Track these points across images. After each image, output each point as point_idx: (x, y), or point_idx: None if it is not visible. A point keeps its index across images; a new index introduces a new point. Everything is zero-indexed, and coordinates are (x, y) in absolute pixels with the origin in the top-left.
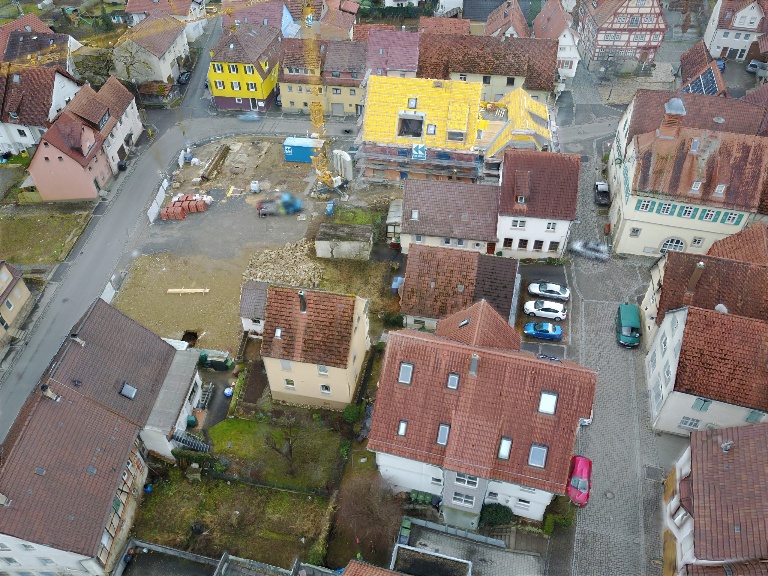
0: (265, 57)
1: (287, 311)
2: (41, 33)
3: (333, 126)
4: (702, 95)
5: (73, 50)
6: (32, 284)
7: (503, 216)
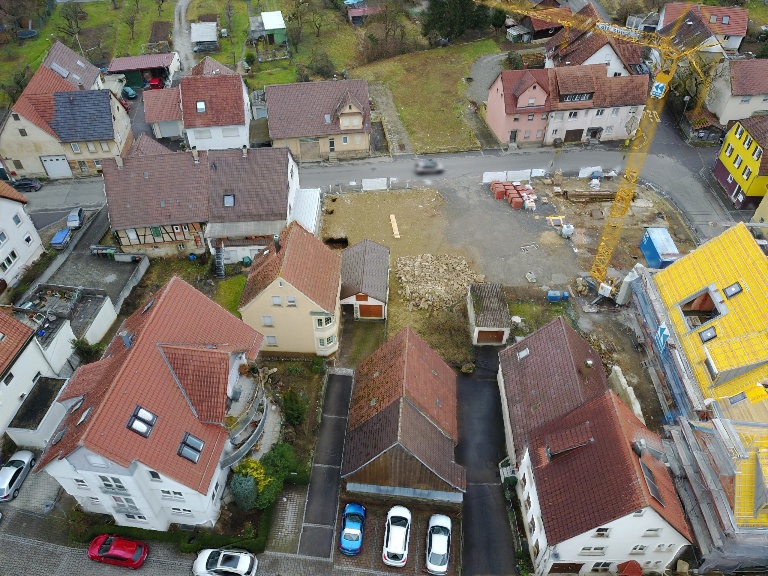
0: None
1: None
2: (702, 22)
3: None
4: None
5: (704, 50)
6: (386, 148)
7: (526, 441)
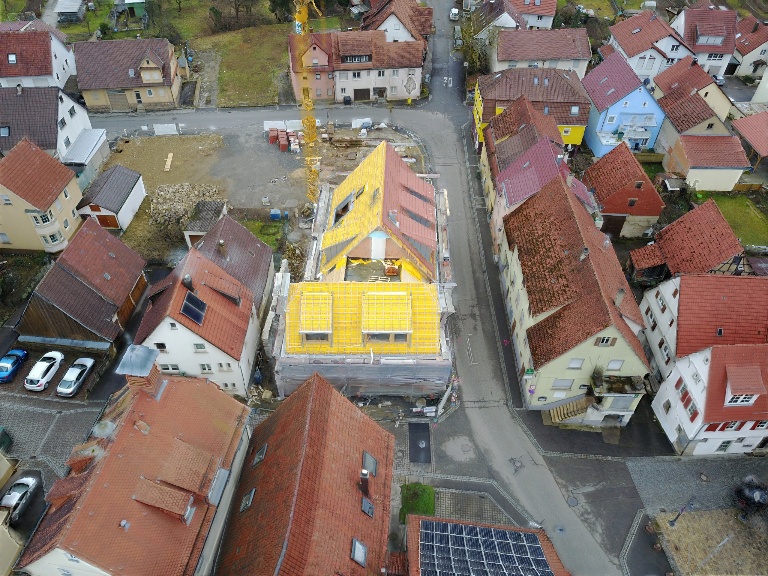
0: None
1: None
2: (503, 1)
3: (460, 202)
4: (296, 476)
5: (500, 25)
6: (192, 103)
7: None
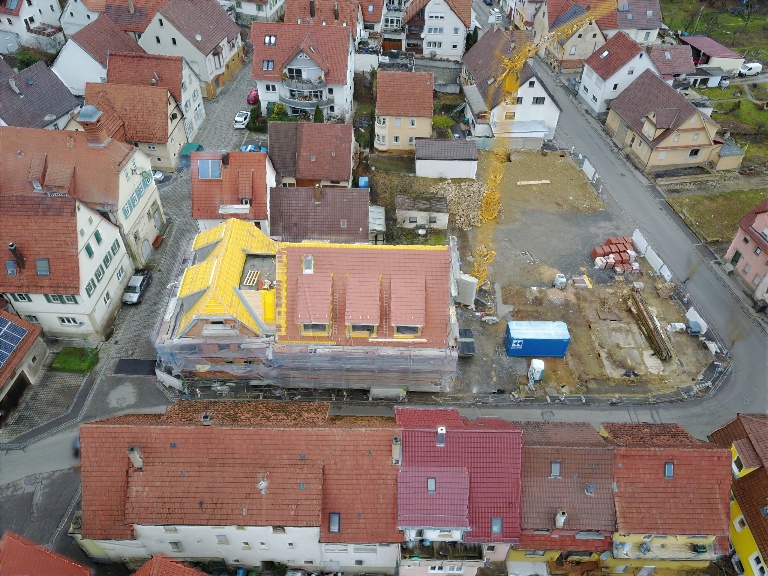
0: (749, 462)
1: None
2: None
3: None
4: None
5: None
6: None
7: None
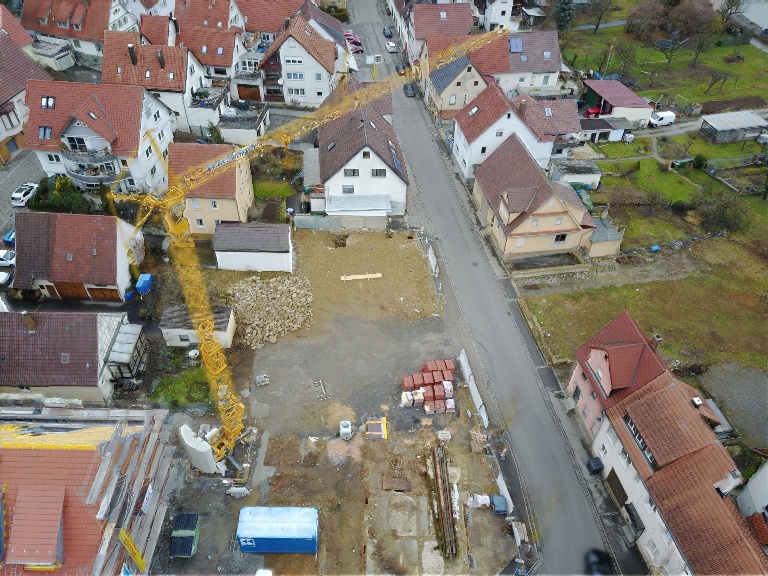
0: None
1: None
2: None
3: None
4: None
5: None
6: None
7: None
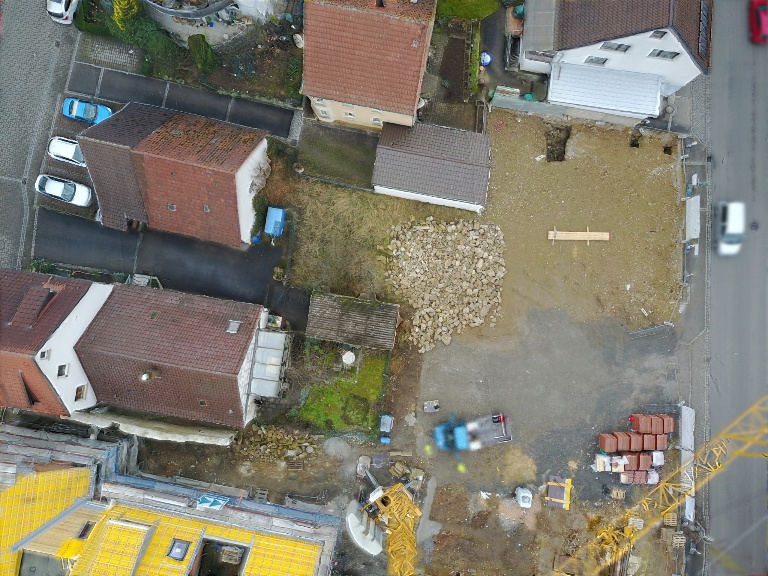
0: None
1: (402, 8)
2: None
3: None
4: None
5: None
6: None
7: (87, 280)
